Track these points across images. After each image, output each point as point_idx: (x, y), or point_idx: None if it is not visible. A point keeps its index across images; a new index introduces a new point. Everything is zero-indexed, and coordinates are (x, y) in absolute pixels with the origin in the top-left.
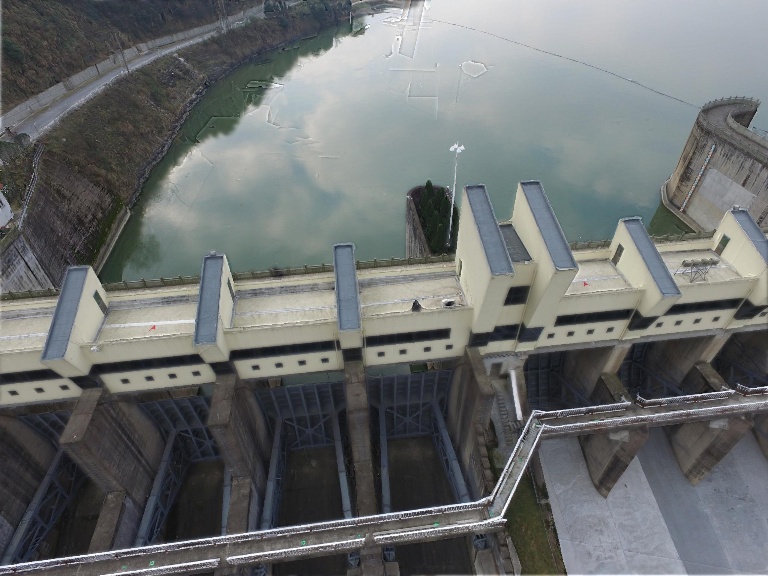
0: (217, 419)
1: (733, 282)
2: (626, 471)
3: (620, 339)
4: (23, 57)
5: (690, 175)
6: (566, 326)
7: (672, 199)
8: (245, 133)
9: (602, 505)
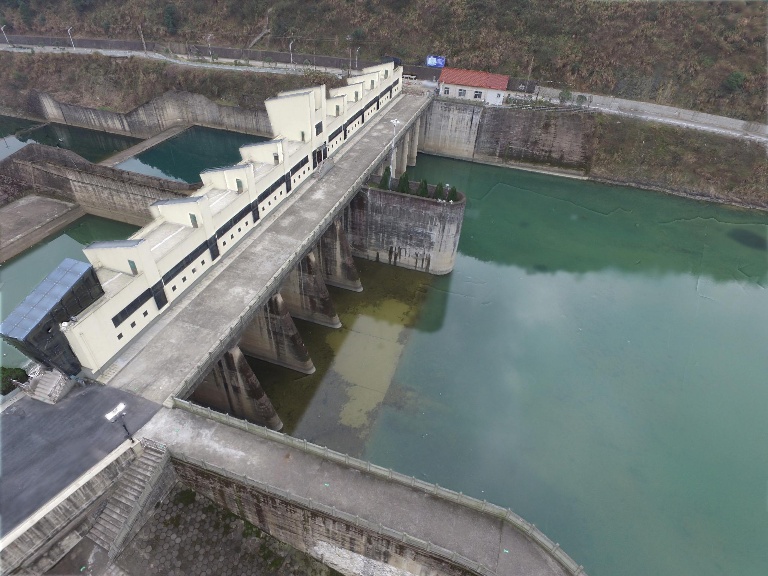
0: None
1: None
2: None
3: None
4: (733, 88)
5: None
6: None
7: None
8: (764, 245)
9: None
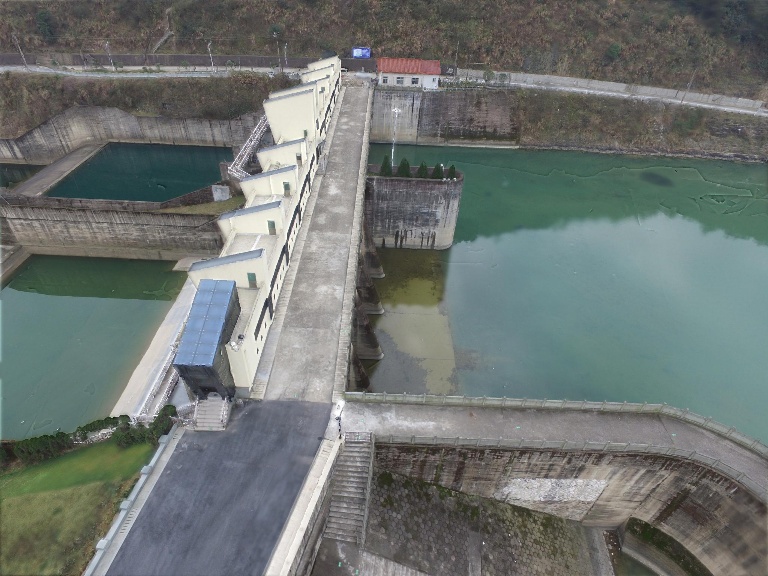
0: None
1: None
2: None
3: None
4: (614, 57)
5: None
6: None
7: None
8: (668, 183)
9: None
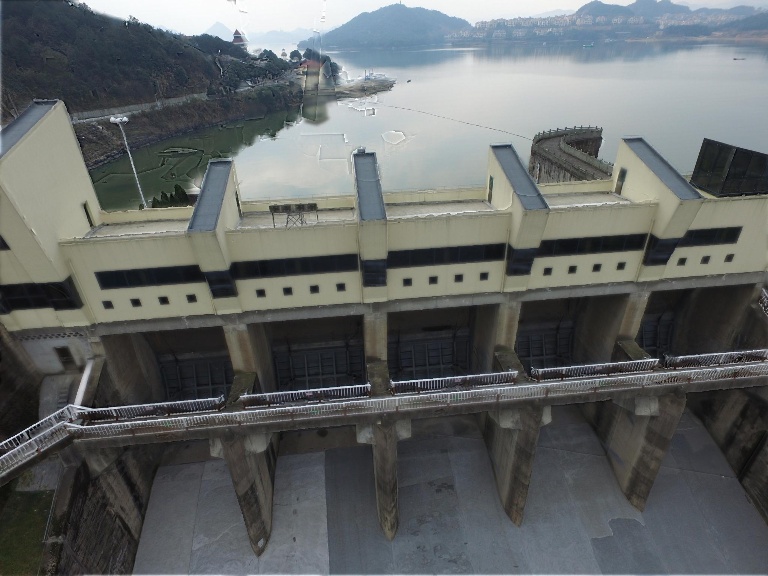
0: None
1: (324, 227)
2: (302, 519)
3: (216, 314)
4: None
5: None
6: (121, 290)
7: None
8: (130, 185)
9: (250, 566)
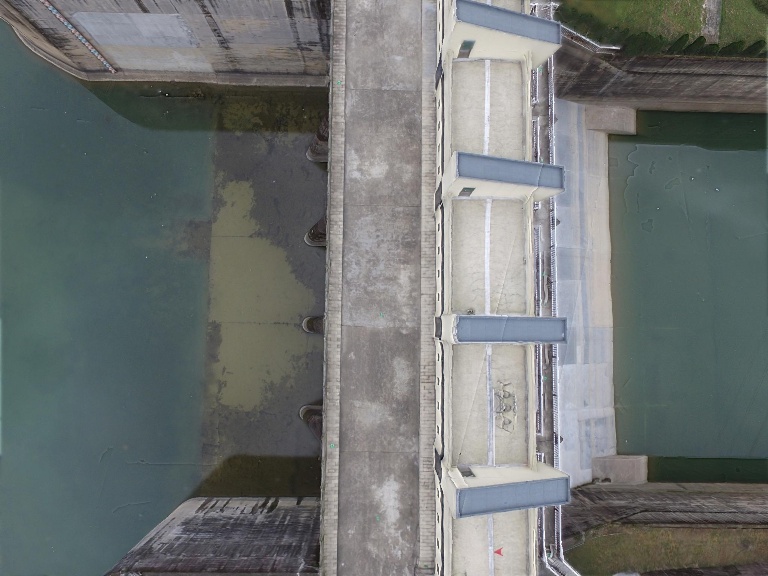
0: None
1: None
2: None
3: None
4: None
5: (59, 35)
6: None
7: (83, 69)
8: None
9: None
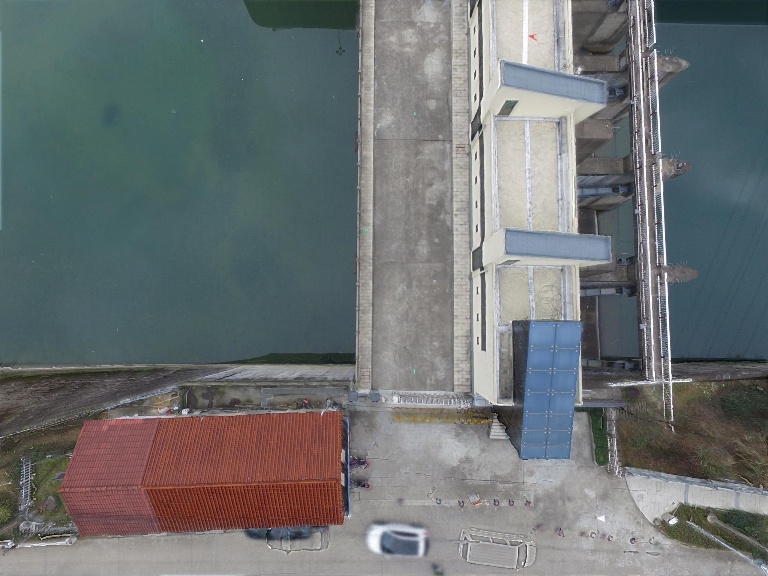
0: (602, 4)
1: None
2: None
3: None
4: None
5: None
6: None
7: None
8: None
9: None
